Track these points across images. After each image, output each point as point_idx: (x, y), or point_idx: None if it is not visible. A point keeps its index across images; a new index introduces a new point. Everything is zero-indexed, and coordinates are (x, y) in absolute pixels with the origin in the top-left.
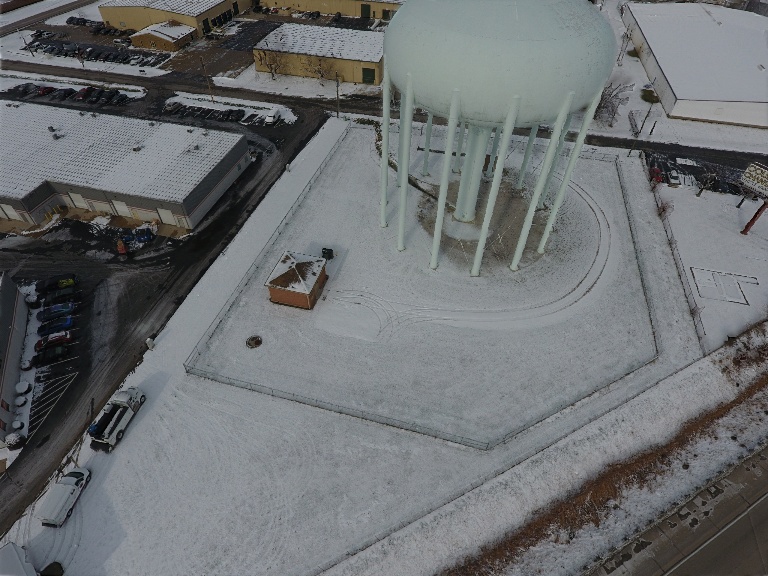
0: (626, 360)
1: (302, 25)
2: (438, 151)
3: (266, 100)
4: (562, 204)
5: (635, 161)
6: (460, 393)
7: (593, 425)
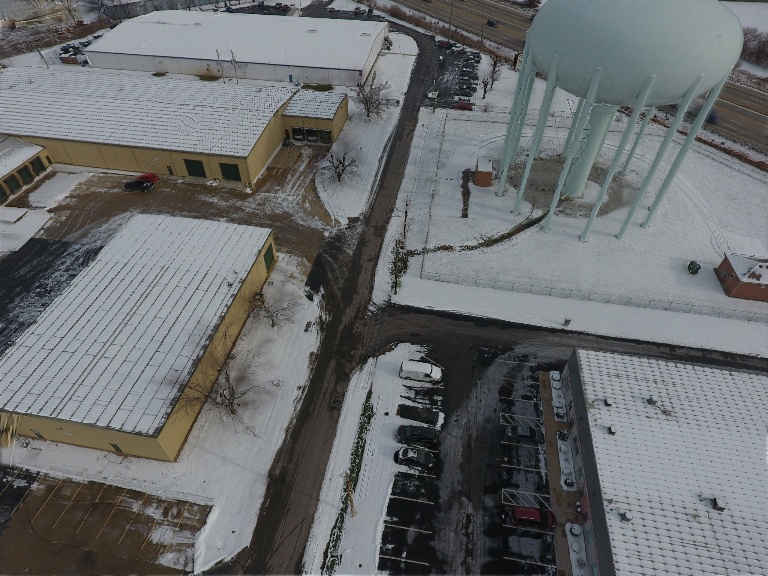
0: (675, 145)
1: (5, 360)
2: (465, 204)
3: (333, 407)
4: (525, 147)
5: (442, 111)
6: (760, 201)
7: (732, 160)
